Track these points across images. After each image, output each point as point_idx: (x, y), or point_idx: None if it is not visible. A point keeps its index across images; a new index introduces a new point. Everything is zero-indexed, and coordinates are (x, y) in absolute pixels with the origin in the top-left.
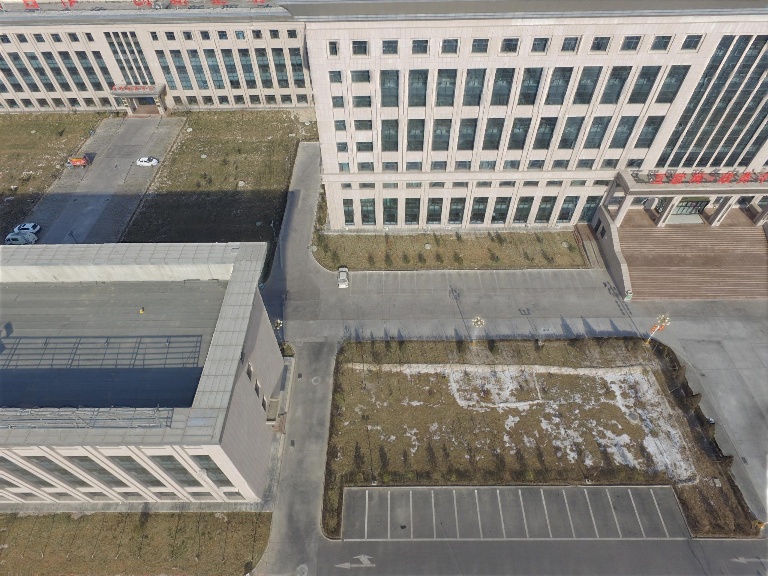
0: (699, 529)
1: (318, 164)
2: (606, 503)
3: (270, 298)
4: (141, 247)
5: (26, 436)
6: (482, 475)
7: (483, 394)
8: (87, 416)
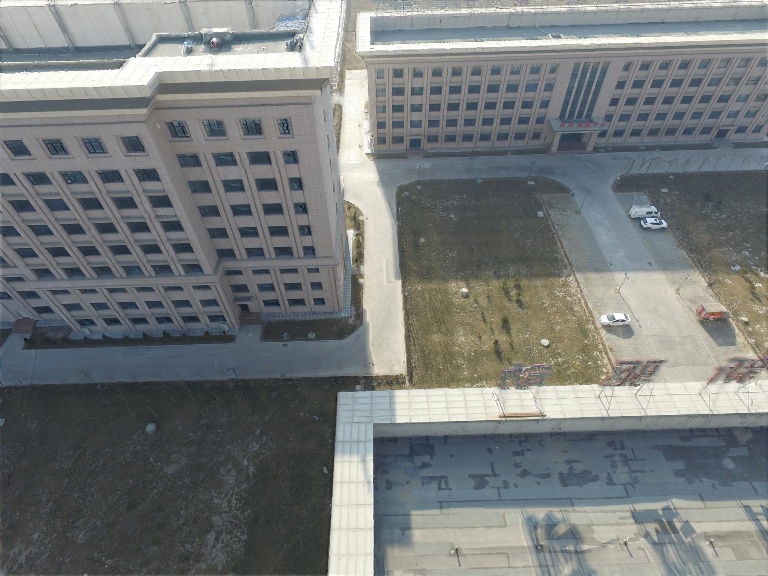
0: None
1: (371, 326)
2: None
3: (390, 182)
4: (426, 47)
5: (425, 10)
6: None
7: None
8: (399, 0)
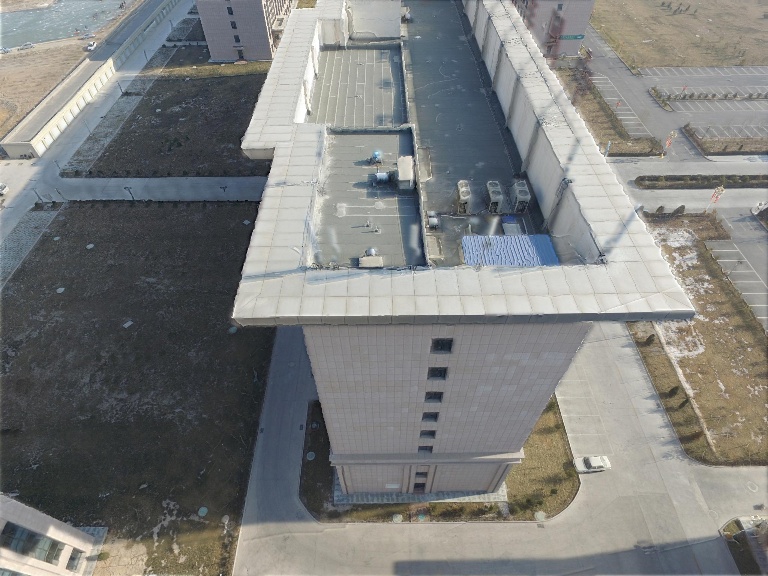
0: (726, 236)
1: (316, 535)
2: (735, 273)
3: (660, 574)
4: None
5: None
6: (761, 340)
7: (684, 333)
8: None
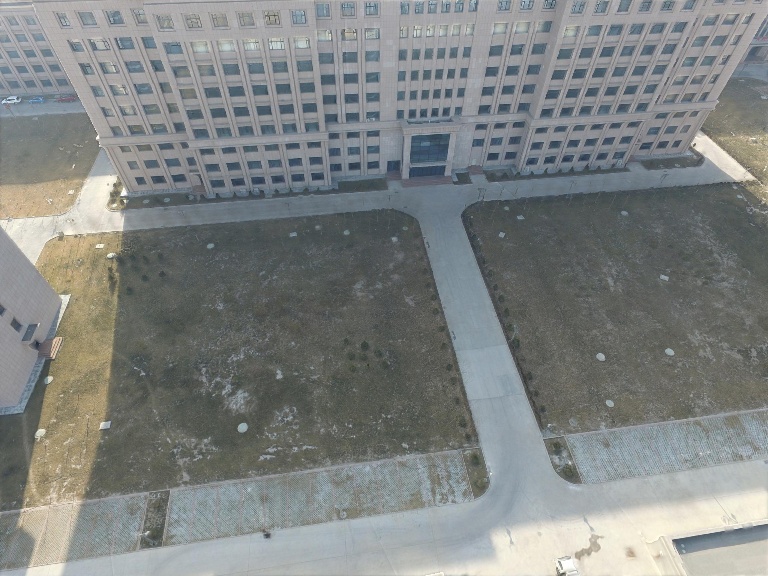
0: None
1: (711, 159)
2: None
3: None
4: None
5: None
6: None
7: None
8: None
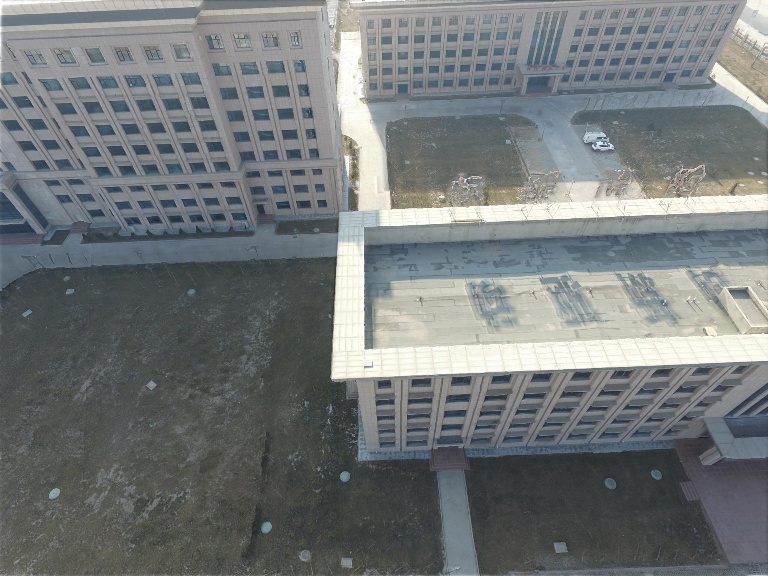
0: None
1: None
2: None
3: (381, 120)
4: None
5: None
6: None
7: None
8: None
